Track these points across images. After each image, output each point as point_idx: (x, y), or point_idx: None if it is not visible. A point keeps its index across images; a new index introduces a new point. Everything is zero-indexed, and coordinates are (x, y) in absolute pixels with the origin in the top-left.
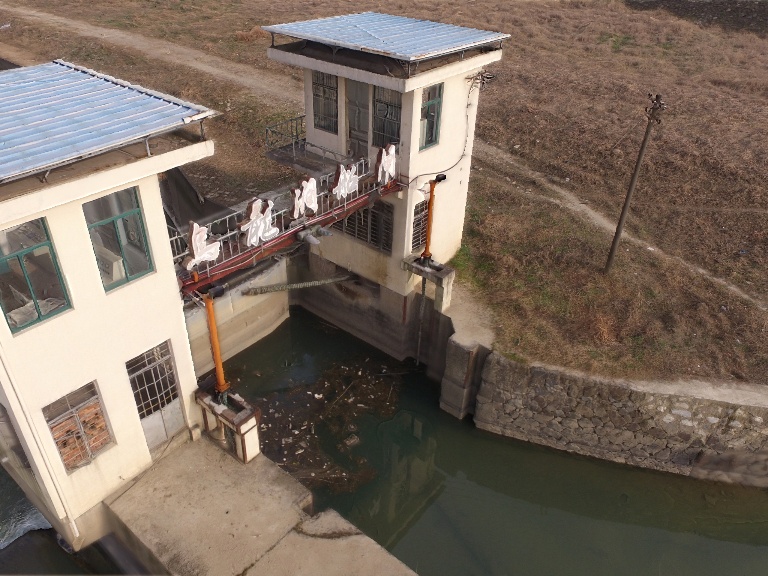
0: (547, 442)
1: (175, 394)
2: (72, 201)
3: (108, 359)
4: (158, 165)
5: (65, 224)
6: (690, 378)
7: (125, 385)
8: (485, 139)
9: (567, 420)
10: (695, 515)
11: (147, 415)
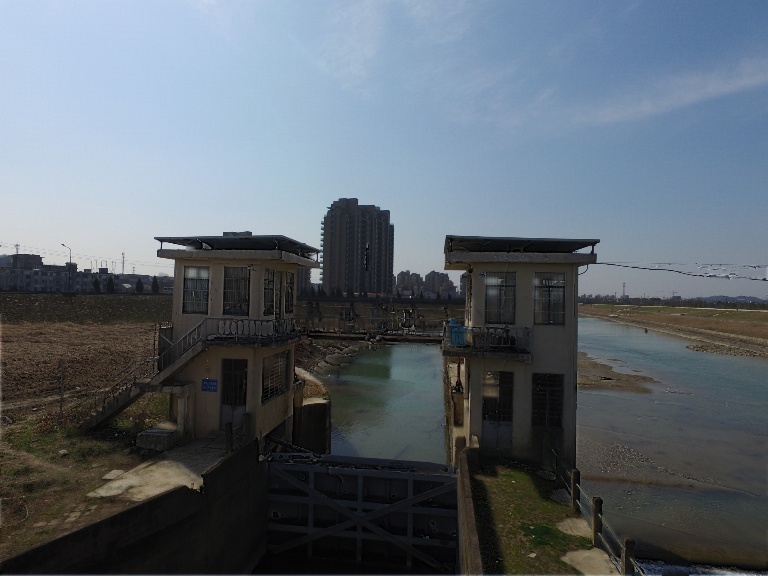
0: None
1: None
2: None
3: None
4: None
5: None
6: None
7: None
8: None
9: None
10: None
11: None
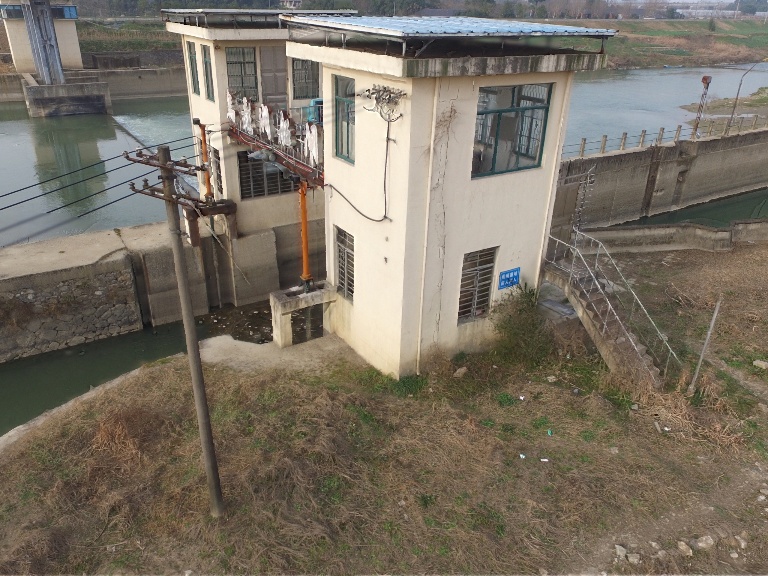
0: None
1: None
2: None
3: None
4: None
5: None
6: None
7: None
8: None
9: None
10: None
11: None
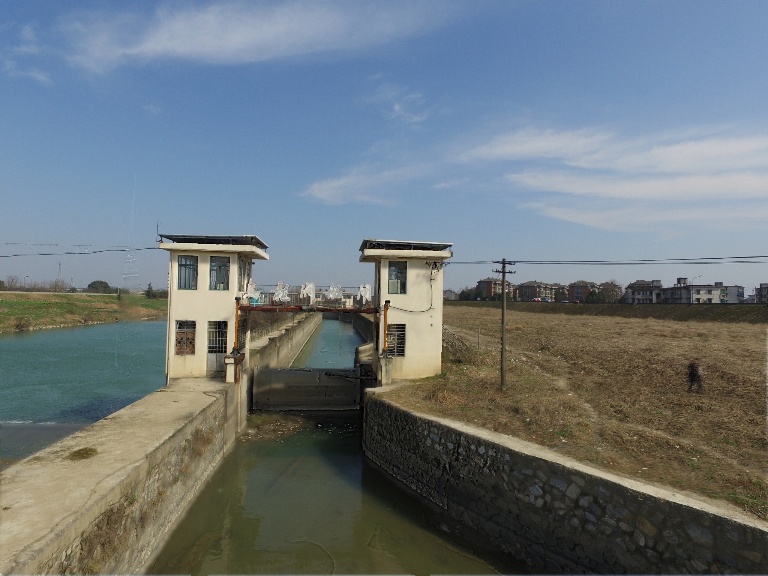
0: (386, 466)
1: (226, 351)
2: (207, 254)
3: (202, 315)
4: (232, 248)
5: (203, 260)
6: (456, 420)
7: (205, 330)
8: (566, 359)
9: (391, 443)
10: (424, 530)
11: (211, 352)
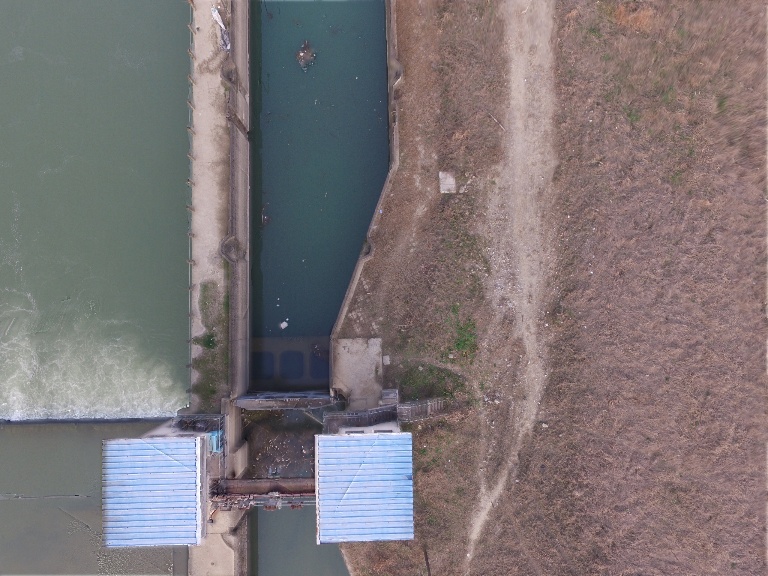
0: None
1: None
2: None
3: None
4: None
5: None
6: None
7: None
8: (543, 398)
9: None
10: None
11: None
